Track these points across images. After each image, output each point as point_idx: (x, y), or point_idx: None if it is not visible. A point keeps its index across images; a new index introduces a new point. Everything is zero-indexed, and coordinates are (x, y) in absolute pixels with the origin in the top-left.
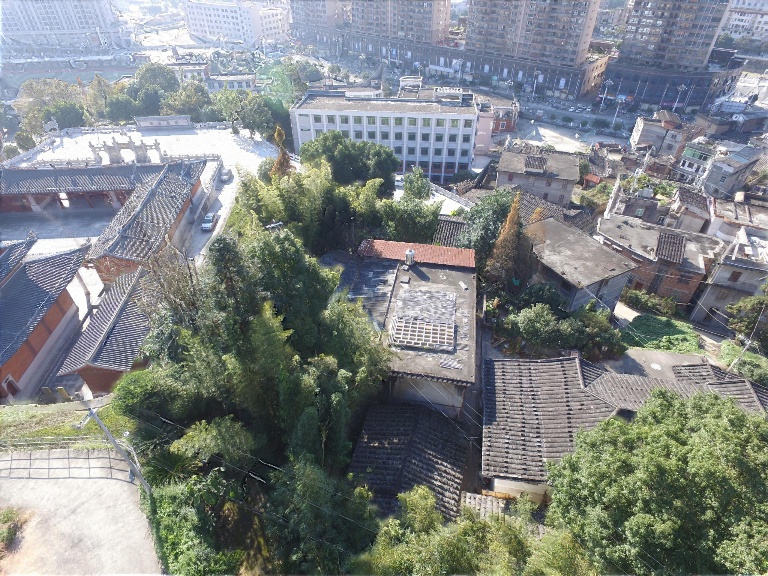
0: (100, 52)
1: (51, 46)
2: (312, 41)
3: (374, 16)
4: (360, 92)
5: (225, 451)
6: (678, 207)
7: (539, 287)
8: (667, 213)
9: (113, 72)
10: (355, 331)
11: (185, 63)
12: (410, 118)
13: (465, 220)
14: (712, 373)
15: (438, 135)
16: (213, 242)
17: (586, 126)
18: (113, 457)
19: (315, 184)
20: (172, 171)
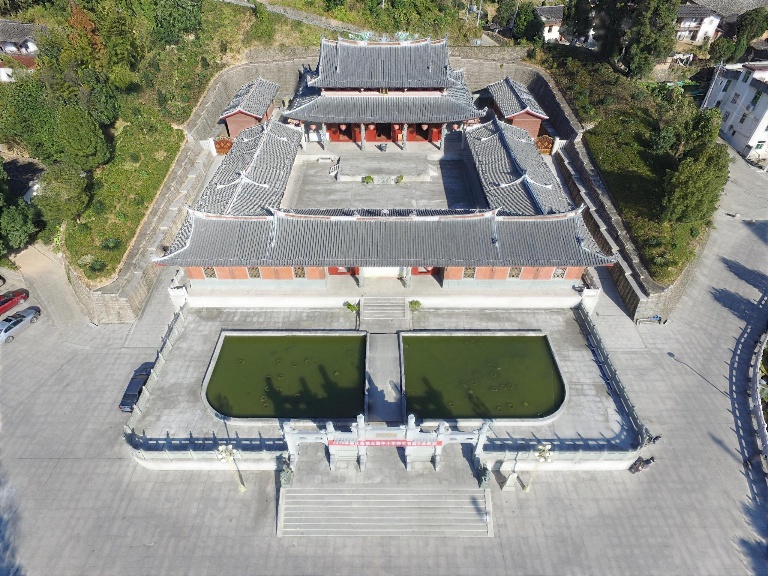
0: None
1: None
2: None
3: None
4: None
5: None
6: None
7: None
8: None
9: None
10: None
11: None
12: None
13: None
14: None
15: None
16: None
17: None
18: None
19: None
20: None
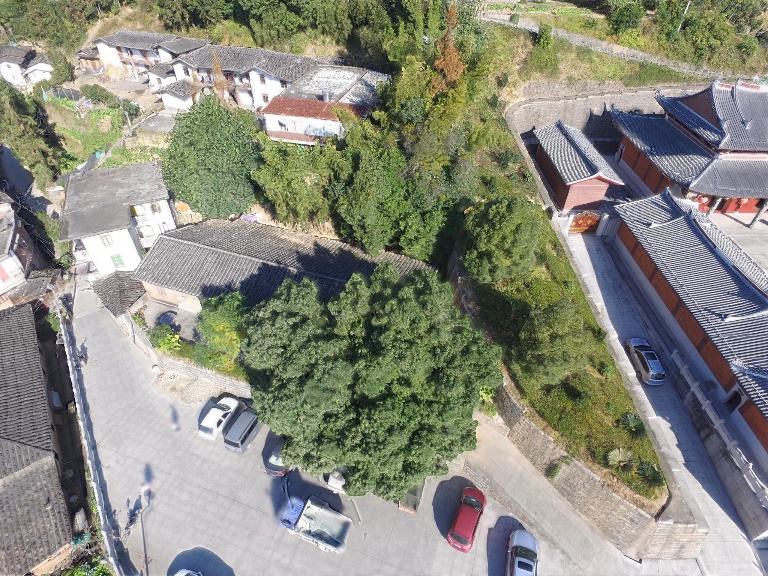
0: None
1: None
2: None
3: None
4: None
5: None
6: None
7: None
8: None
9: None
10: None
11: None
12: None
13: None
14: (171, 87)
15: None
16: None
17: None
18: None
19: None
20: None
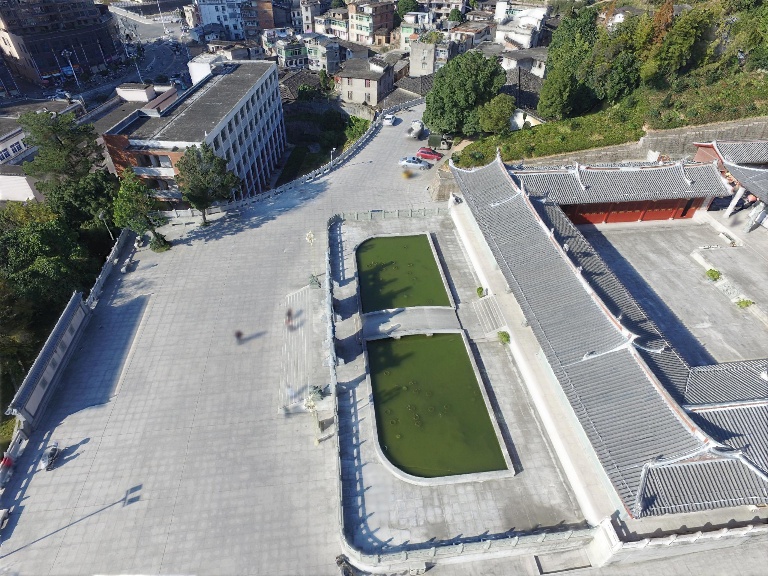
0: None
1: None
2: None
3: None
4: None
5: None
6: (460, 38)
7: None
8: (459, 44)
9: None
10: None
11: None
12: None
13: None
14: None
15: None
16: None
17: None
18: None
19: None
20: None
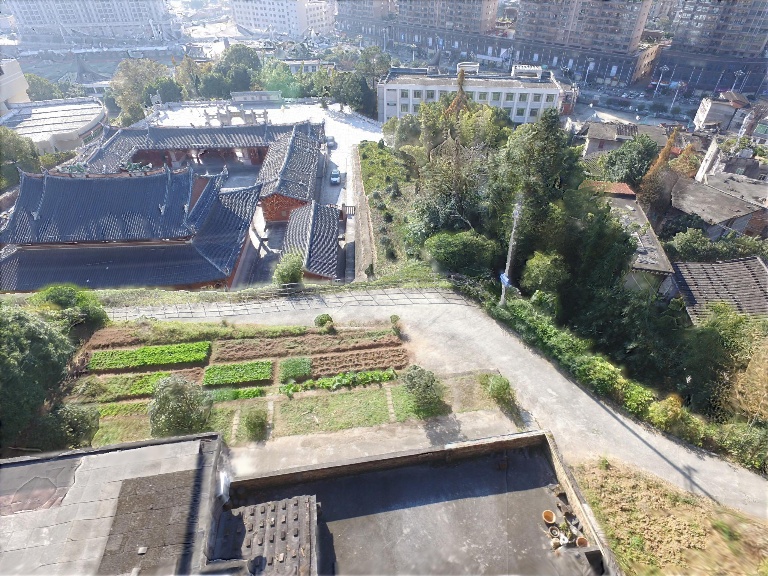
0: (155, 43)
1: (106, 38)
2: (357, 33)
3: (422, 7)
4: None
5: (552, 277)
6: None
7: (687, 216)
8: None
9: (169, 61)
10: None
11: (254, 48)
12: (494, 93)
13: (601, 164)
14: None
15: (519, 109)
16: (549, 111)
17: (643, 110)
18: (441, 292)
19: (488, 122)
20: (300, 131)
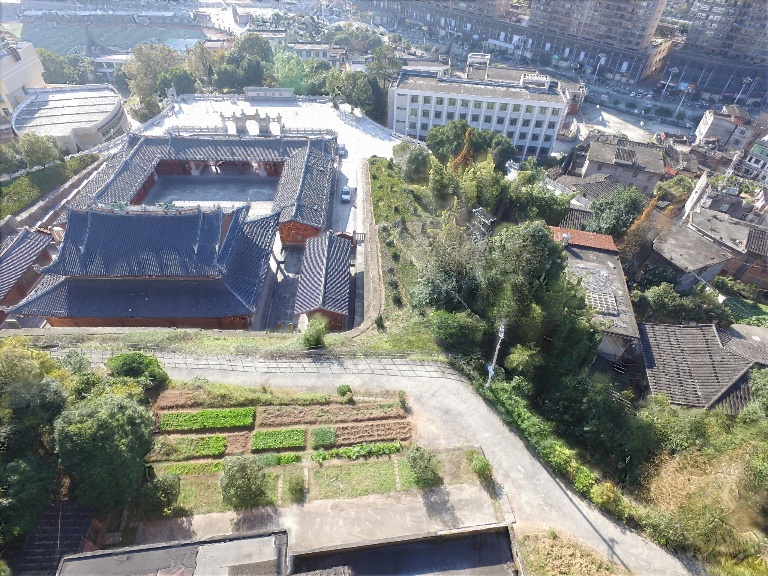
0: (161, 7)
1: None
2: (368, 6)
3: None
4: (429, 67)
5: (530, 365)
6: (762, 206)
7: (663, 270)
8: (751, 210)
9: (176, 29)
10: (579, 294)
11: (265, 30)
12: (502, 103)
13: (593, 209)
14: None
15: (525, 120)
16: (537, 231)
17: (649, 113)
18: (440, 366)
19: (490, 175)
20: (314, 147)
